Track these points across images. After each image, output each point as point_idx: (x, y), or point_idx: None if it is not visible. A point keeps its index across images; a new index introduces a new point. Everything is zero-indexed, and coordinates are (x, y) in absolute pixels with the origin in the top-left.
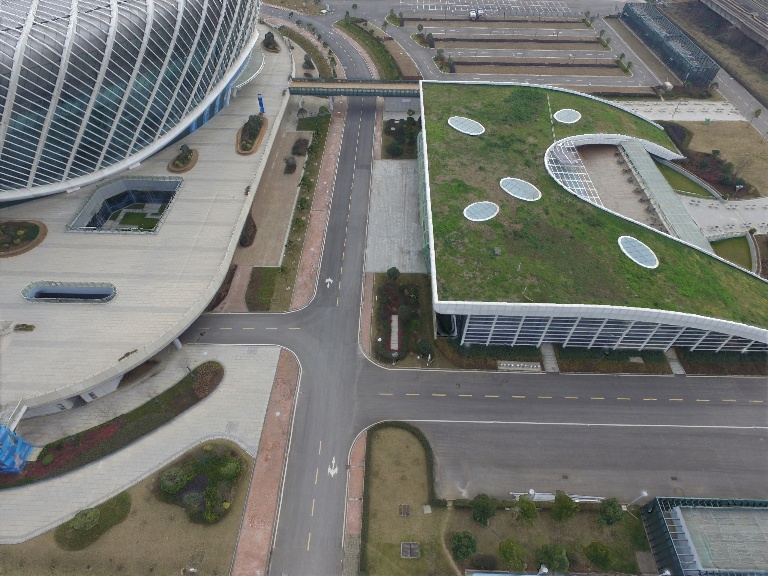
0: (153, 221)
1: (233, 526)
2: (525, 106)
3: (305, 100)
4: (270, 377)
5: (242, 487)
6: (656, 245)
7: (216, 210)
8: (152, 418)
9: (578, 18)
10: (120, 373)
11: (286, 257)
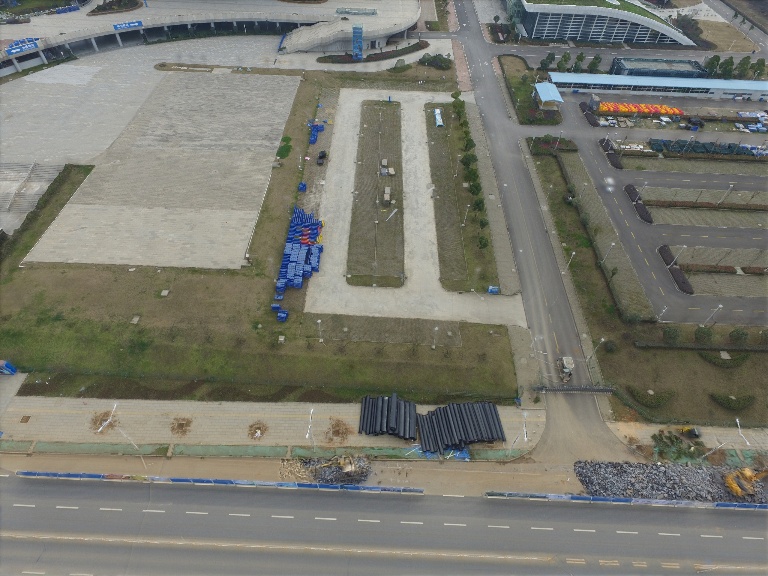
0: None
1: (454, 71)
2: None
3: None
4: (450, 45)
5: (453, 65)
6: (620, 1)
7: None
8: None
9: None
10: (393, 32)
11: (439, 19)
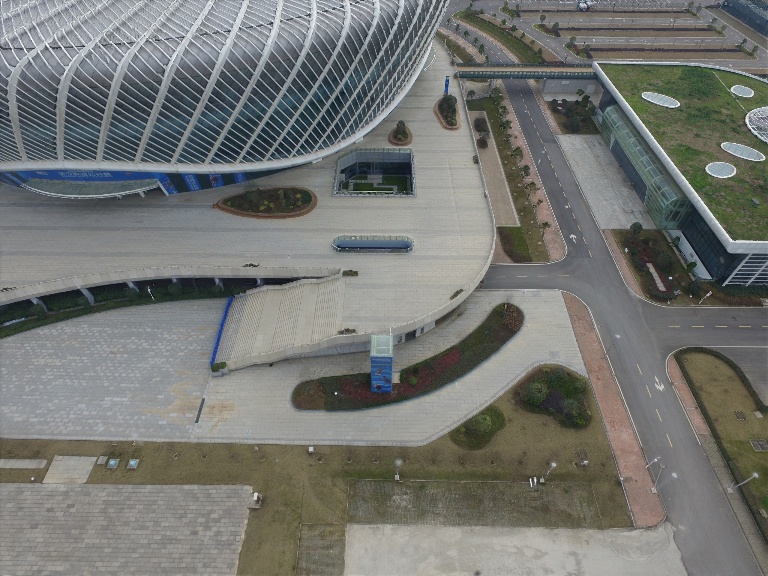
0: (383, 190)
1: (599, 430)
2: (701, 83)
3: (462, 84)
4: (565, 315)
5: (590, 400)
6: None
7: (456, 176)
8: (484, 347)
9: (680, 8)
10: (452, 309)
11: (522, 218)
